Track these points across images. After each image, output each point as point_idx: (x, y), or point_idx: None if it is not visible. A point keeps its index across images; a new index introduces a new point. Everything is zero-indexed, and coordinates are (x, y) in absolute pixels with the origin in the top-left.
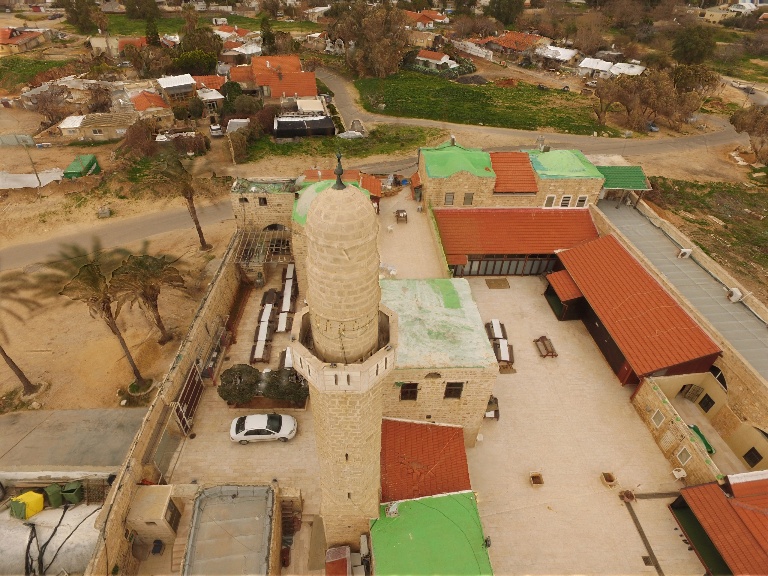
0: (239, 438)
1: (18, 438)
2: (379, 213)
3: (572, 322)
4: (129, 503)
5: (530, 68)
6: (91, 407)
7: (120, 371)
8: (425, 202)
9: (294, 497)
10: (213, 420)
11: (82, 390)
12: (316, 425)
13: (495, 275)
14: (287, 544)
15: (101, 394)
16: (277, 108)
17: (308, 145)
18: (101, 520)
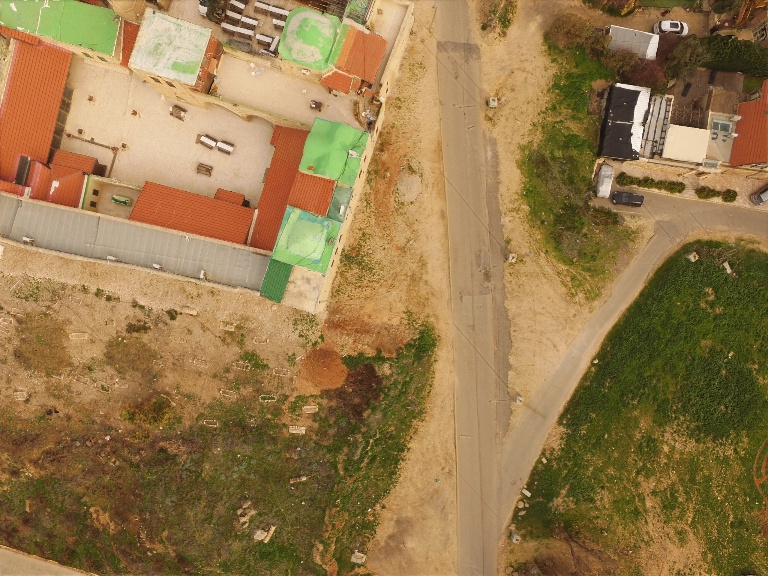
0: None
1: None
2: (330, 93)
3: None
4: None
5: None
6: None
7: None
8: None
9: None
10: None
11: None
12: None
13: None
14: (154, 3)
15: None
16: (707, 107)
17: (572, 116)
18: None
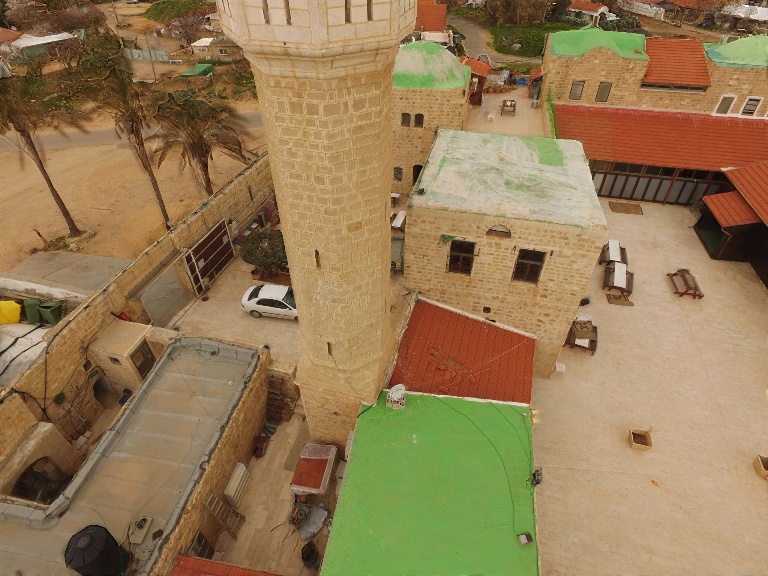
0: (250, 306)
1: (47, 272)
2: (481, 104)
3: (733, 263)
4: (97, 331)
5: (712, 29)
6: (121, 257)
7: (160, 231)
8: (543, 93)
9: (285, 373)
10: (232, 288)
11: (120, 242)
12: (277, 196)
13: (624, 198)
14: (268, 432)
15: (135, 248)
16: None
17: None
18: (52, 333)
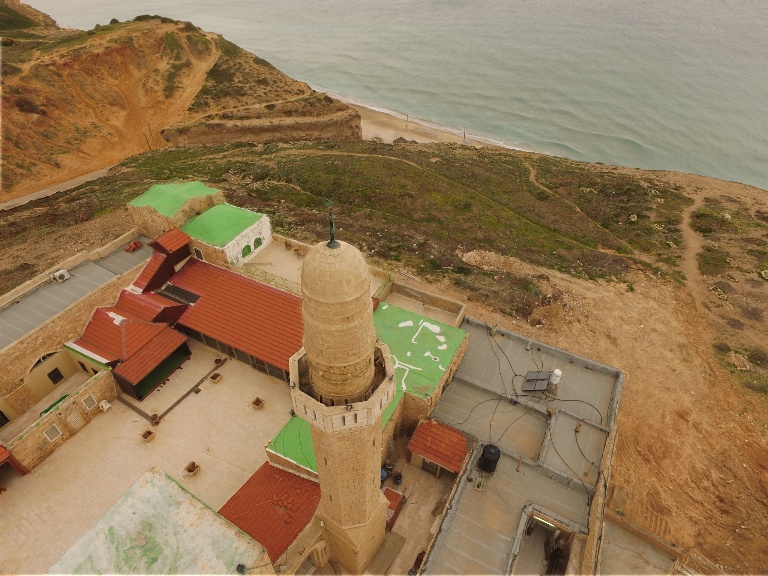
0: None
1: None
2: None
3: None
4: None
5: None
6: None
7: None
8: None
9: None
10: None
11: None
12: None
13: None
14: (415, 572)
15: None
16: None
17: None
18: None
